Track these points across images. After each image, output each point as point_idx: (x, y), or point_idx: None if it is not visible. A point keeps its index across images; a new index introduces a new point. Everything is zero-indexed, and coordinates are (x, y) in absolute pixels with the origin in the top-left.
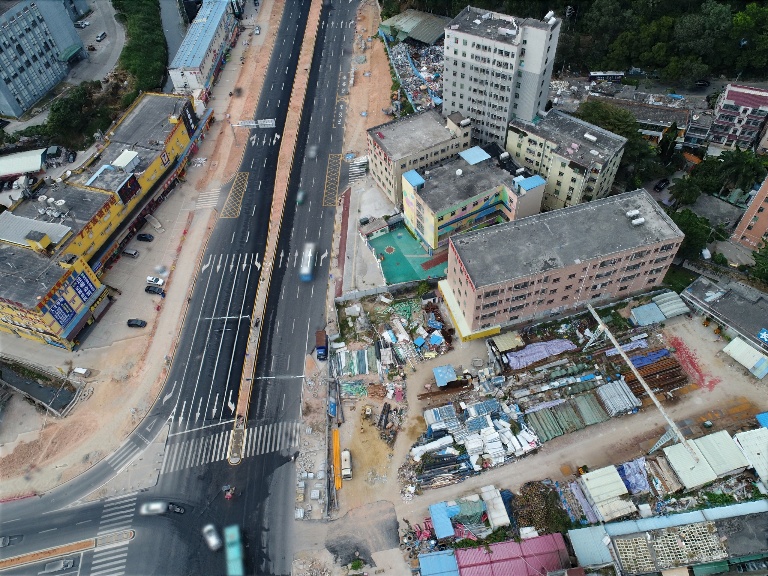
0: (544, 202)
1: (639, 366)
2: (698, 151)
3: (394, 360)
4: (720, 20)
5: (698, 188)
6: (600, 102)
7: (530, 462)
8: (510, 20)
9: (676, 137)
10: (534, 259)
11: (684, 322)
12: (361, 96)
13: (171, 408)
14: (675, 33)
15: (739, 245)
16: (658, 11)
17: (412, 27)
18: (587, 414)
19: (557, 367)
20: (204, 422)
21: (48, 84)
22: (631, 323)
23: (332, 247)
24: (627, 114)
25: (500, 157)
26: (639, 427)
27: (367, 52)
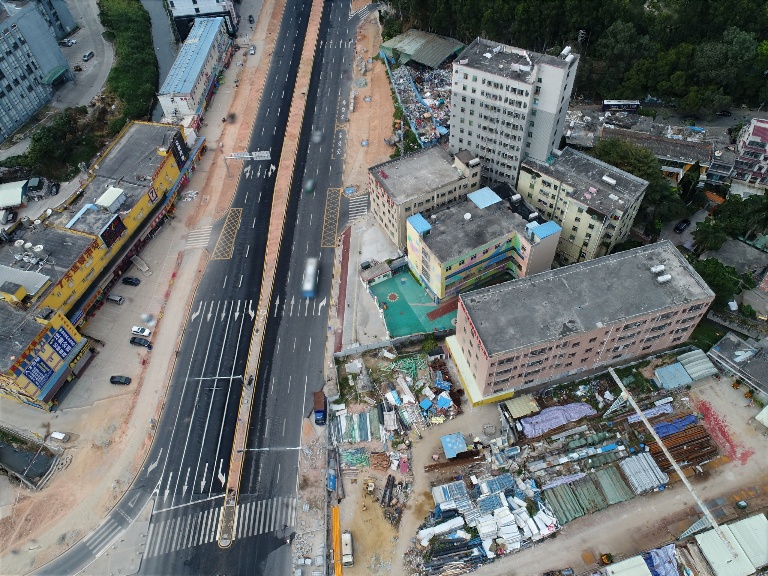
0: (558, 246)
1: (665, 435)
2: (720, 189)
3: (398, 425)
4: (744, 49)
5: (724, 235)
6: (619, 140)
7: (548, 548)
8: (523, 54)
9: (699, 177)
10: (552, 321)
11: (712, 384)
12: (361, 123)
13: (156, 480)
14: (695, 61)
15: (767, 295)
16: (676, 36)
17: (415, 49)
18: (610, 491)
19: (575, 435)
20: (192, 497)
21: (31, 108)
22: (654, 385)
23: (331, 293)
24: (648, 154)
25: (511, 199)
26: (667, 507)
27: (367, 75)
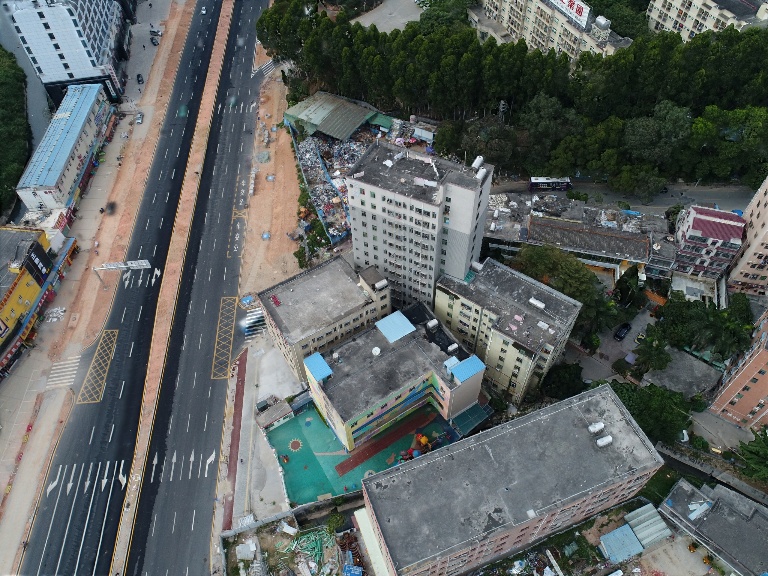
0: (485, 372)
1: None
2: (661, 285)
3: None
4: (677, 127)
5: (669, 357)
6: (546, 249)
7: None
8: (429, 162)
9: (637, 282)
10: (474, 512)
11: (665, 546)
12: (263, 209)
13: None
14: (626, 138)
15: (719, 418)
16: (604, 106)
17: (322, 118)
18: None
19: None
20: None
21: None
22: (601, 554)
23: (221, 445)
24: (579, 267)
25: (427, 326)
26: None
27: (271, 146)
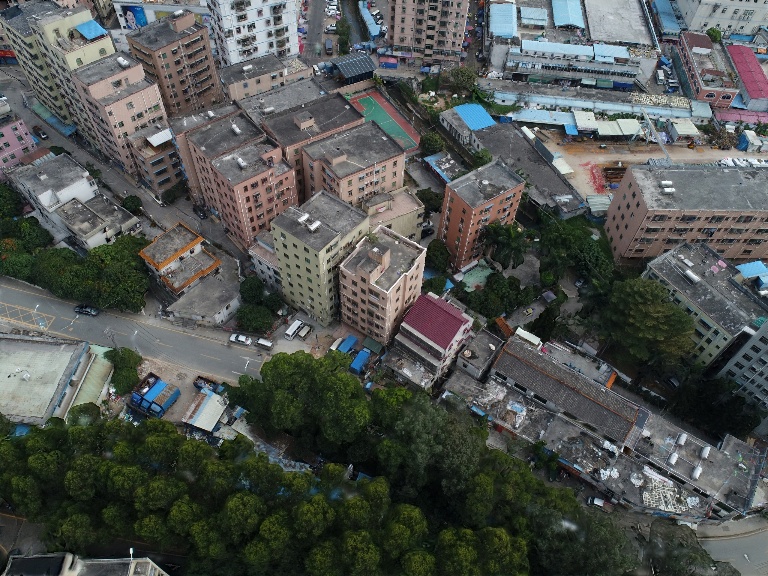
0: None
1: None
2: None
3: None
4: None
5: None
6: (674, 315)
7: None
8: None
9: None
10: (764, 181)
11: None
12: None
13: None
14: None
15: None
16: None
17: None
18: None
19: None
20: None
21: None
22: None
23: None
24: None
25: None
26: (647, 157)
27: None
